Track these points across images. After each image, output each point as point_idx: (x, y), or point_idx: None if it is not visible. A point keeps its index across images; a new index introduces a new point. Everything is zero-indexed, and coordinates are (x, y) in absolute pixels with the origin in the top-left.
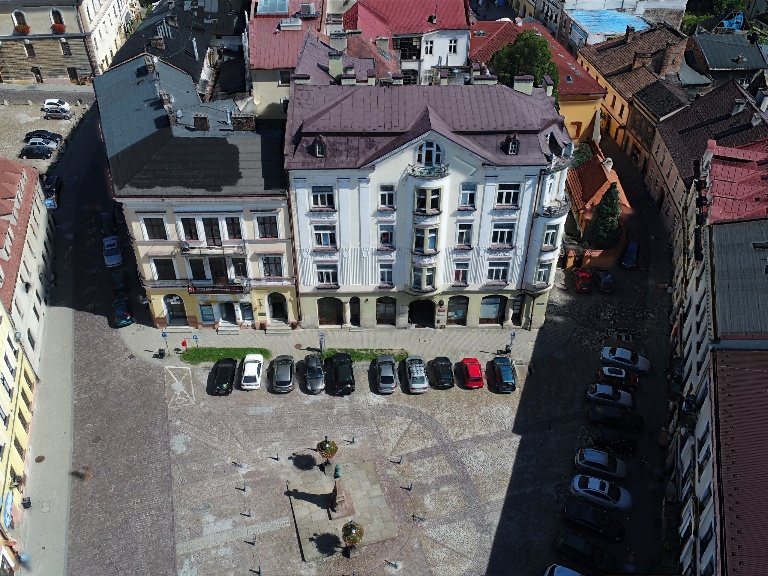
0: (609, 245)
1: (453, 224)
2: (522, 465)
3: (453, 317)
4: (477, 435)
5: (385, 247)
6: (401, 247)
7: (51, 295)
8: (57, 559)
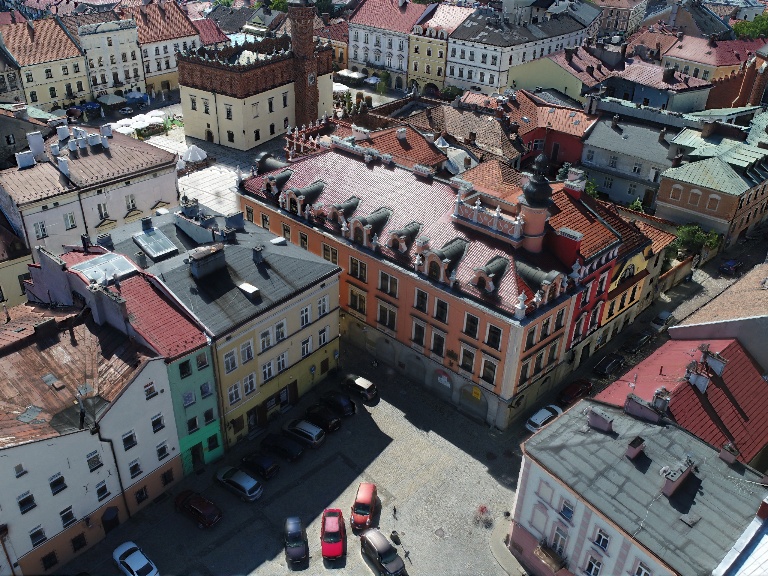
0: None
1: None
2: None
3: None
4: None
5: None
6: None
7: None
8: None
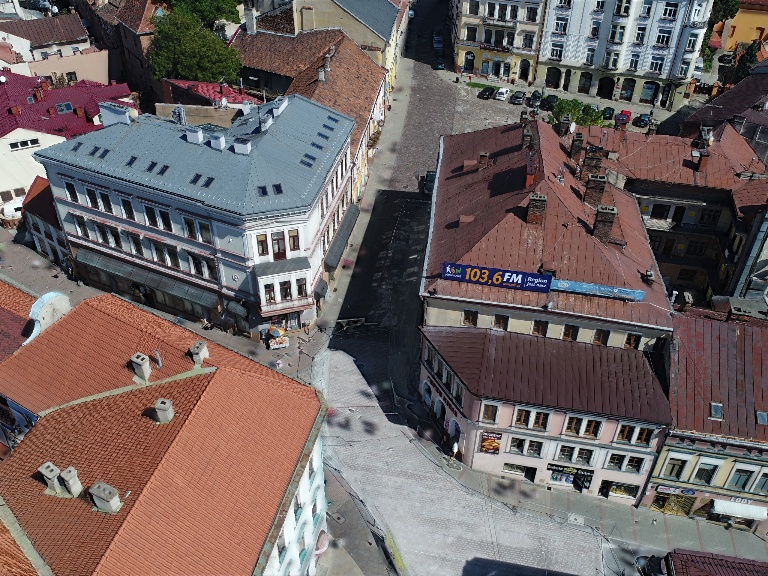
0: None
1: (635, 26)
2: None
3: (624, 95)
4: None
5: (593, 37)
6: (602, 38)
7: (404, 54)
8: (400, 125)
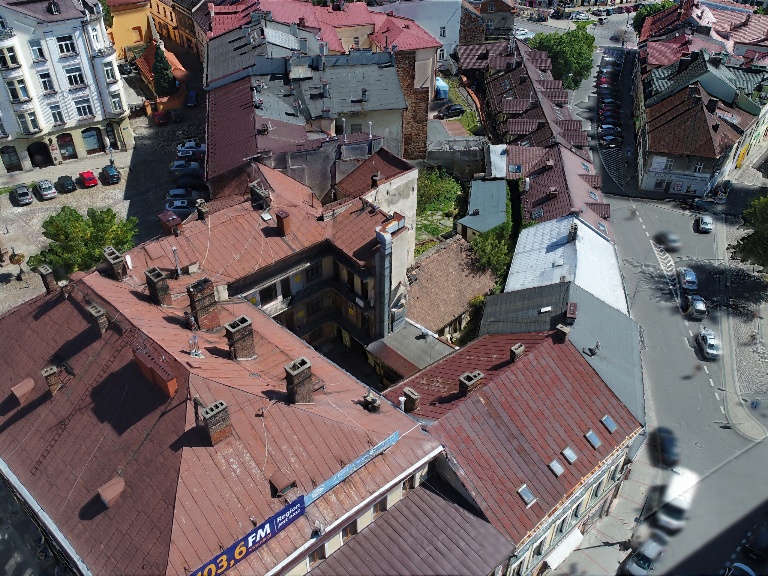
0: (172, 92)
1: (35, 75)
2: (133, 212)
3: (66, 154)
4: (99, 207)
5: None
6: (2, 101)
7: None
8: None
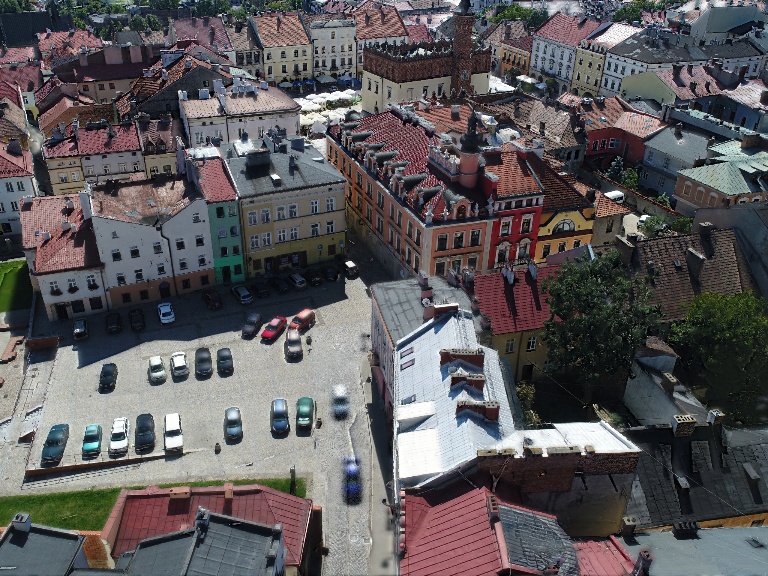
0: None
1: None
2: None
3: None
4: None
5: None
6: None
7: None
8: None
